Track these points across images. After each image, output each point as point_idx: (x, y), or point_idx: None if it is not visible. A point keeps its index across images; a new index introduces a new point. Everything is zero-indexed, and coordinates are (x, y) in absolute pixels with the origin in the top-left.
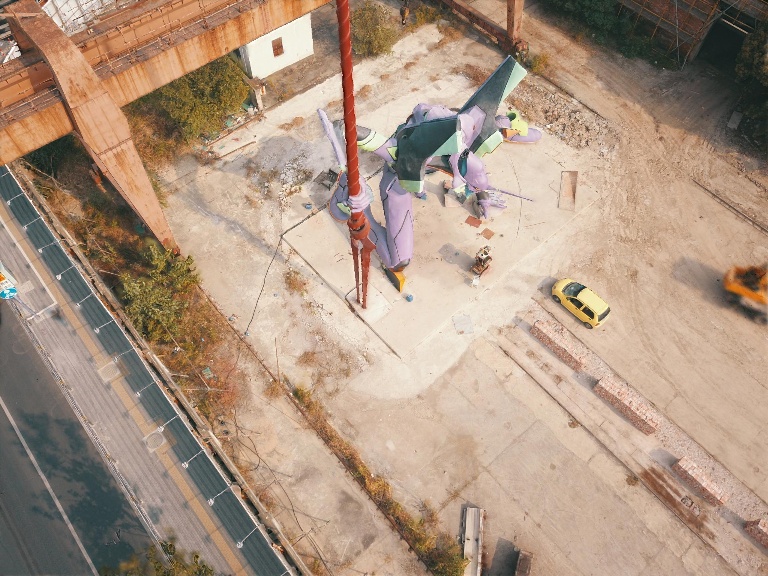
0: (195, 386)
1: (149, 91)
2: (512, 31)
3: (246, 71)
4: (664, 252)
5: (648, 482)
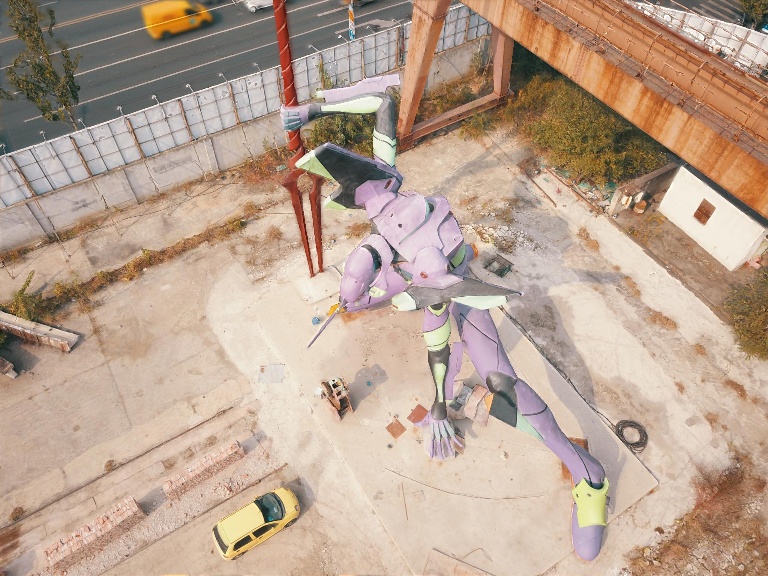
0: None
1: (475, 10)
2: None
3: None
4: None
5: (6, 534)
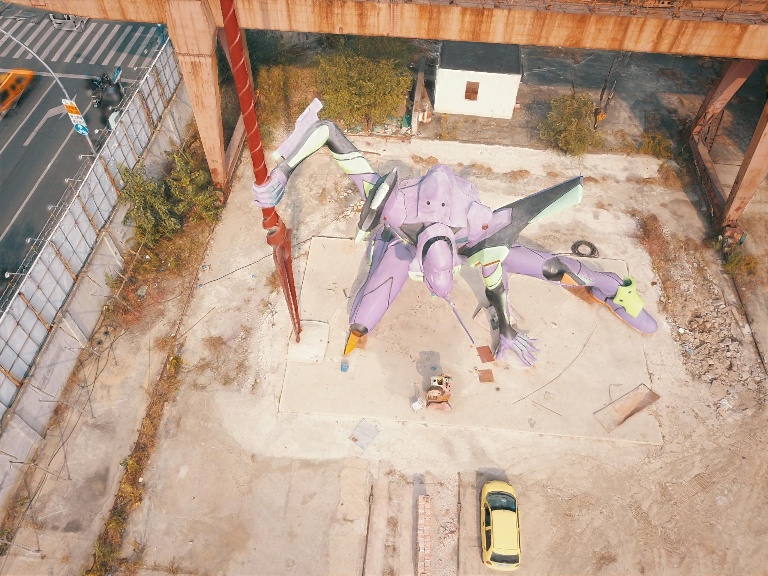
0: (124, 291)
1: (251, 27)
2: (729, 208)
3: (434, 98)
4: (678, 572)
5: None
